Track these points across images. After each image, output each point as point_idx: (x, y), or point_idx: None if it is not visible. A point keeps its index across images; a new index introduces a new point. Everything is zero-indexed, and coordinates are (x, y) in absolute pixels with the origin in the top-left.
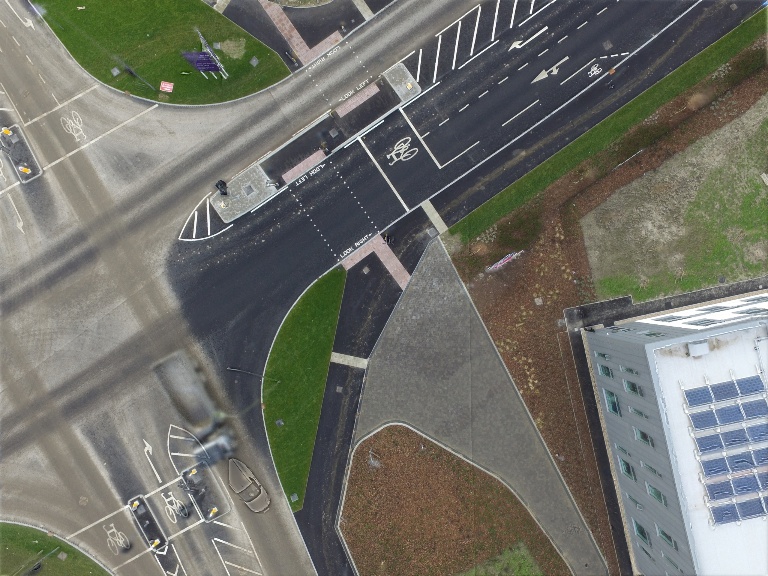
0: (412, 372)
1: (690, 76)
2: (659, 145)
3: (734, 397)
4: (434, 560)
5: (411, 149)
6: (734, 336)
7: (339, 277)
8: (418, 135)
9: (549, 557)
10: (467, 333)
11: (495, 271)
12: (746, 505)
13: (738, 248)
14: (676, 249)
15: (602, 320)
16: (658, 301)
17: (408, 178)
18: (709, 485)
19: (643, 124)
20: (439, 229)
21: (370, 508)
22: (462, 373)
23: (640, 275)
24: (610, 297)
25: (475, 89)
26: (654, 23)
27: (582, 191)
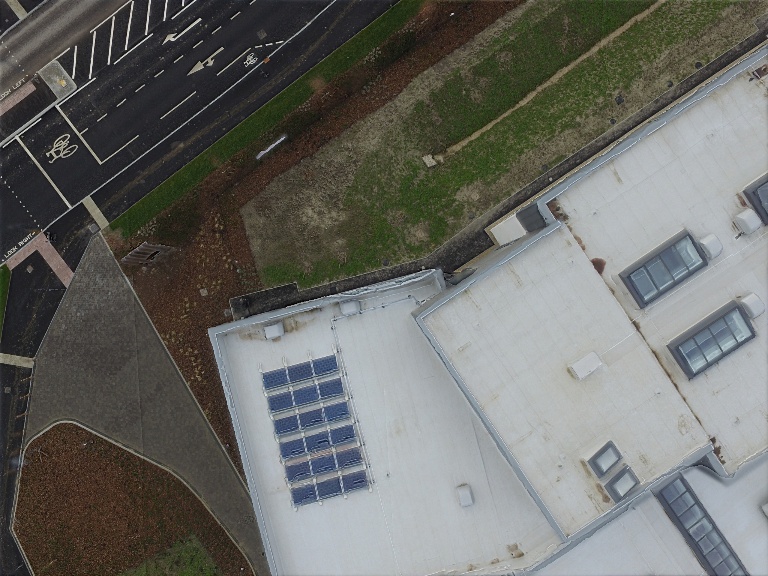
0: (79, 369)
1: (342, 62)
2: (314, 131)
3: (308, 377)
4: (104, 557)
5: (70, 146)
6: (312, 317)
7: (2, 277)
8: (77, 132)
9: (223, 548)
10: (133, 327)
11: (158, 264)
12: (331, 485)
13: (398, 230)
14: (337, 234)
15: (268, 308)
16: (323, 286)
17: (69, 175)
18: (288, 466)
19: (297, 111)
20: (100, 225)
21: (40, 508)
22: (129, 368)
23: (303, 261)
24: (275, 285)
25: (131, 83)
26: (307, 11)
27: (240, 180)
